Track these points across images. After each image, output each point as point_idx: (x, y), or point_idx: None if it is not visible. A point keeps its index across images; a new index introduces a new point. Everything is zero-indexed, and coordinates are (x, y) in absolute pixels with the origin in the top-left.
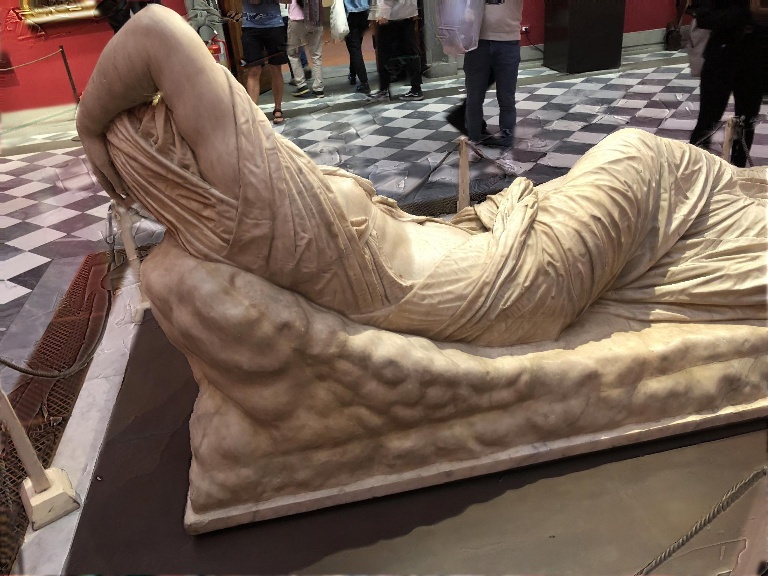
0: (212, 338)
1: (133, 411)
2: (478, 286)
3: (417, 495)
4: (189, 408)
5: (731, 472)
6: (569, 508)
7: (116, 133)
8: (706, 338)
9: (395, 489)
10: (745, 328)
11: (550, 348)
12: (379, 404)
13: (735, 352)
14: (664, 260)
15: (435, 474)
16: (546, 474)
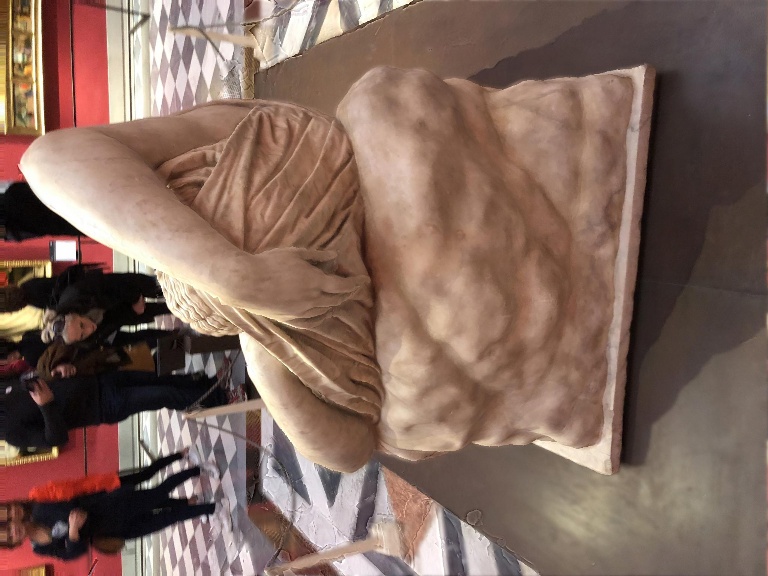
0: (409, 74)
1: (755, 372)
2: None
3: None
4: (667, 329)
5: None
6: None
7: (224, 206)
8: None
9: None
10: None
11: None
12: None
13: None
14: None
15: None
16: None
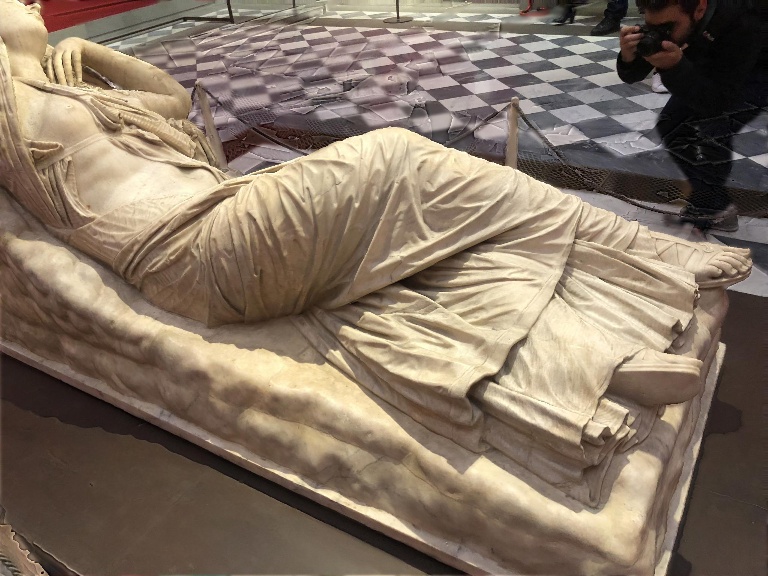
0: None
1: None
2: (131, 241)
3: (88, 397)
4: None
5: (268, 549)
6: (134, 476)
7: None
8: (332, 404)
9: (72, 382)
10: (383, 419)
11: (195, 331)
12: (39, 305)
13: (355, 437)
14: (371, 300)
15: (91, 387)
16: (165, 442)
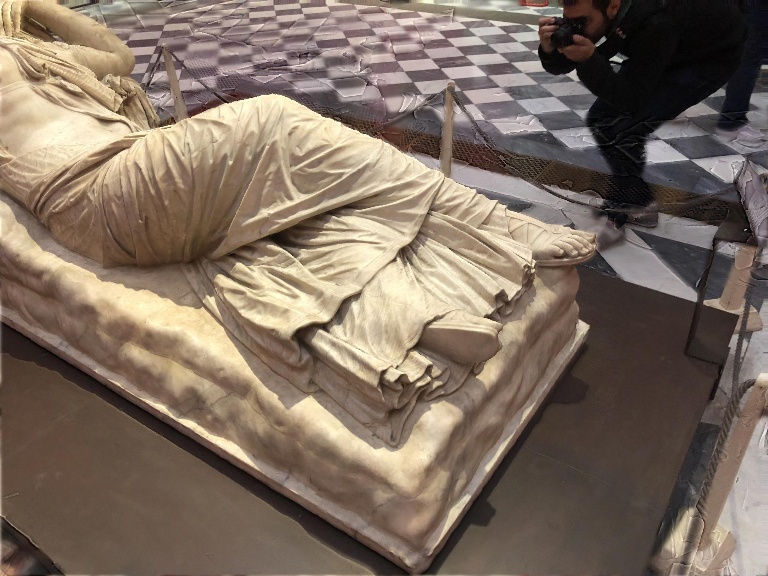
0: None
1: None
2: (38, 182)
3: (4, 326)
4: None
5: (128, 467)
6: (27, 397)
7: None
8: (195, 342)
9: None
10: (235, 358)
11: (91, 269)
12: None
13: (210, 373)
14: (244, 253)
15: (4, 316)
16: (62, 370)
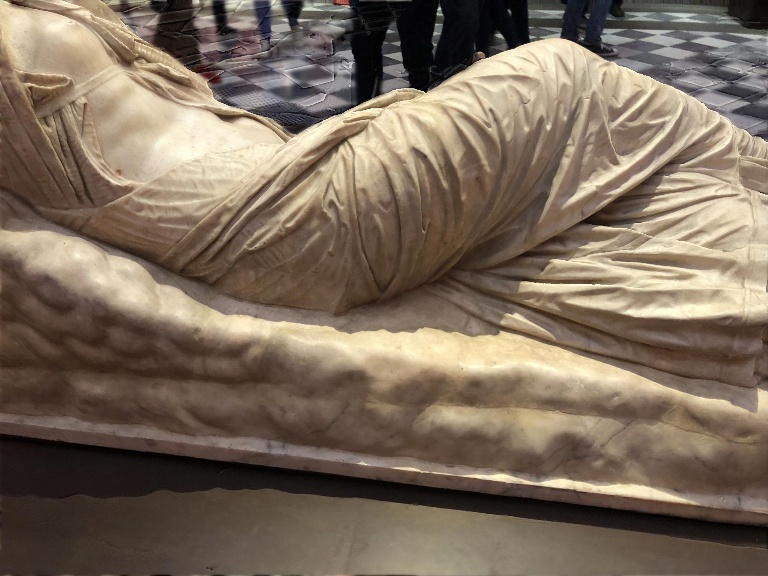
0: None
1: None
2: (215, 210)
3: (115, 455)
4: None
5: (513, 572)
6: (265, 539)
7: None
8: (555, 373)
9: (85, 439)
10: (626, 376)
11: (319, 322)
12: (44, 329)
13: (594, 406)
14: (551, 246)
15: (131, 437)
16: (277, 484)
